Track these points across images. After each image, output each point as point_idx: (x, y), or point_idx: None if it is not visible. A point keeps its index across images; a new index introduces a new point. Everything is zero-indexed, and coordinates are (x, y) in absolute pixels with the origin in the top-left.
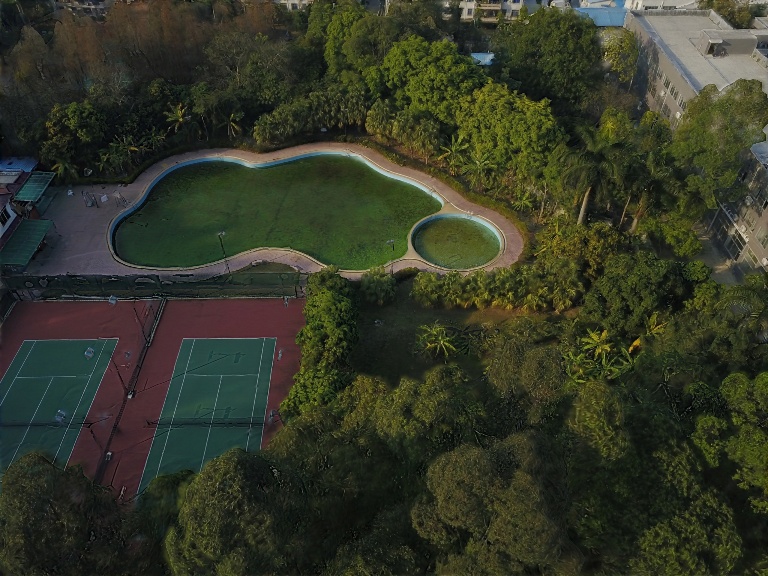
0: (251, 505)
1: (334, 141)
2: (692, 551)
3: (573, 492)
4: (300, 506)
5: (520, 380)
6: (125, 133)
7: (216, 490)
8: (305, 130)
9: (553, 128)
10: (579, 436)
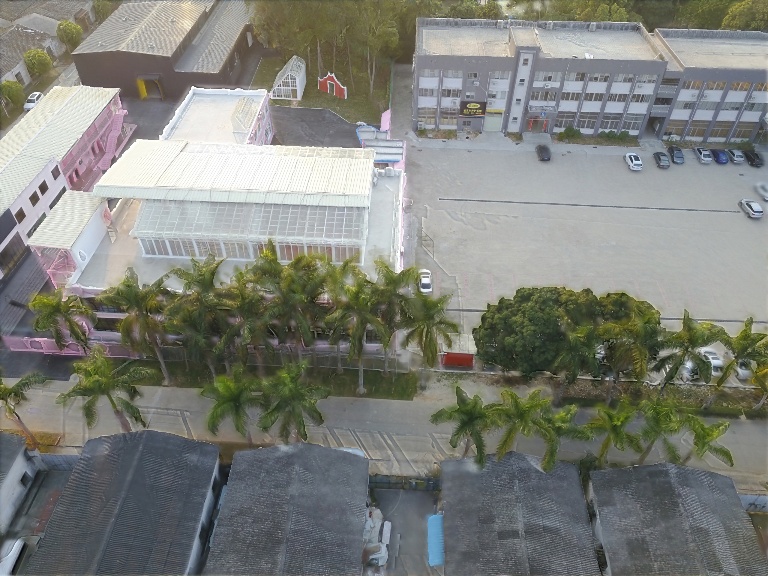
0: None
1: None
2: None
3: None
4: None
5: None
6: None
7: None
8: None
9: None
10: None
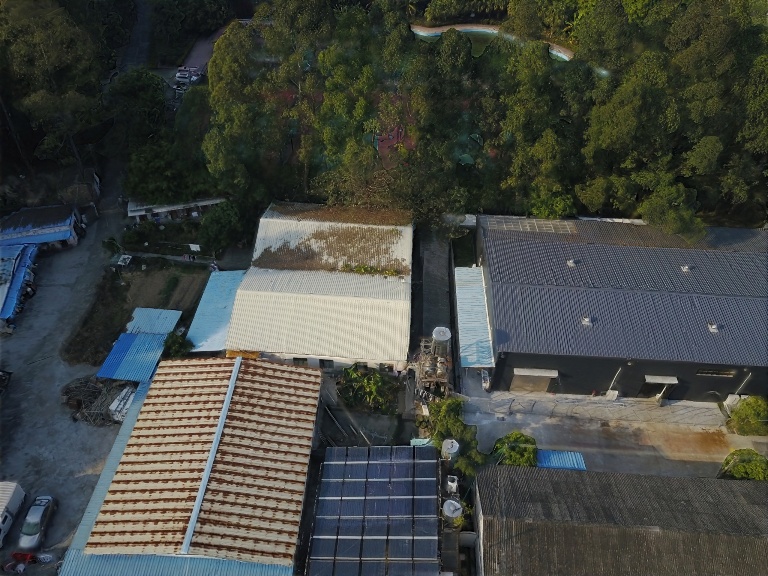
0: (622, 8)
1: (480, 23)
2: None
3: None
4: None
5: (704, 3)
6: (342, 4)
7: (610, 1)
8: (462, 12)
9: (652, 1)
10: (732, 17)
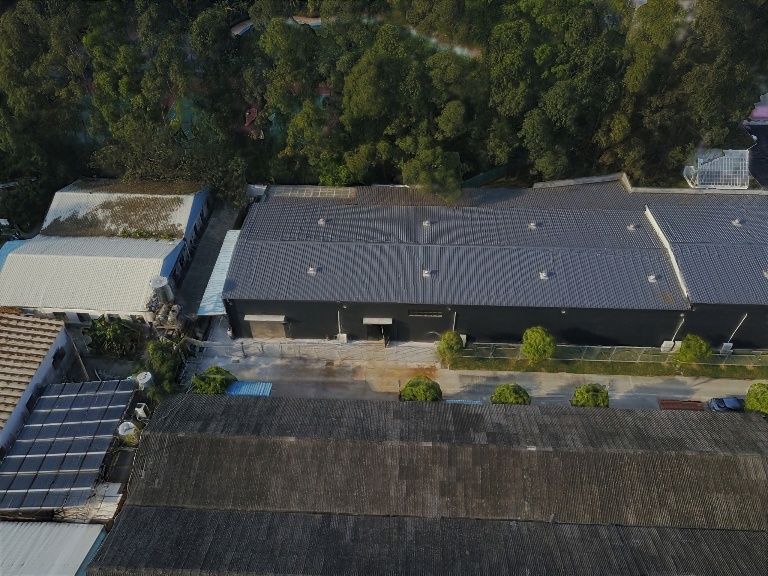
0: None
1: None
2: (510, 32)
3: (469, 19)
4: (366, 2)
5: None
6: None
7: None
8: None
9: None
10: None
